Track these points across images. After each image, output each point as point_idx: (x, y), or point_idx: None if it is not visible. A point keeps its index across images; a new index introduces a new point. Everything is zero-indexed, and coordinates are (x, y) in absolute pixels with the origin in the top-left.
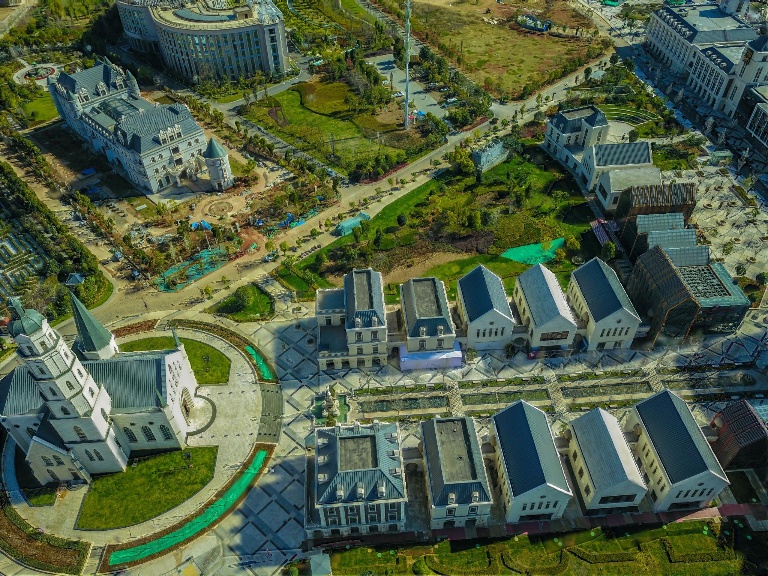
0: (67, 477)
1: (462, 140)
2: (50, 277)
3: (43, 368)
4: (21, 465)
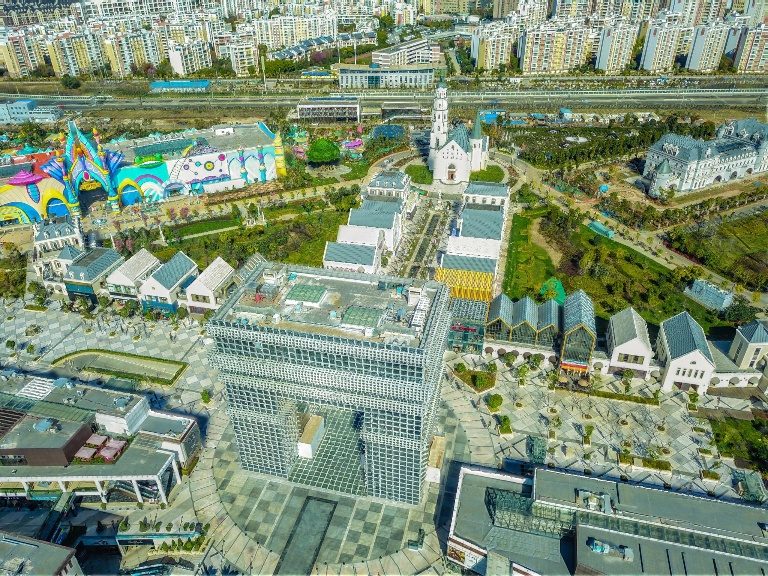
0: None
1: None
2: None
3: None
4: None
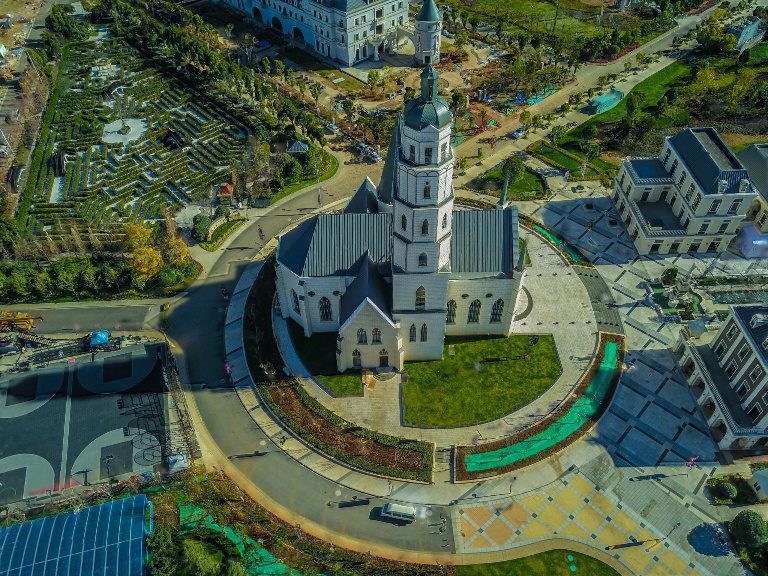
0: (373, 363)
1: (705, 18)
2: (263, 145)
3: (432, 187)
4: (303, 348)
